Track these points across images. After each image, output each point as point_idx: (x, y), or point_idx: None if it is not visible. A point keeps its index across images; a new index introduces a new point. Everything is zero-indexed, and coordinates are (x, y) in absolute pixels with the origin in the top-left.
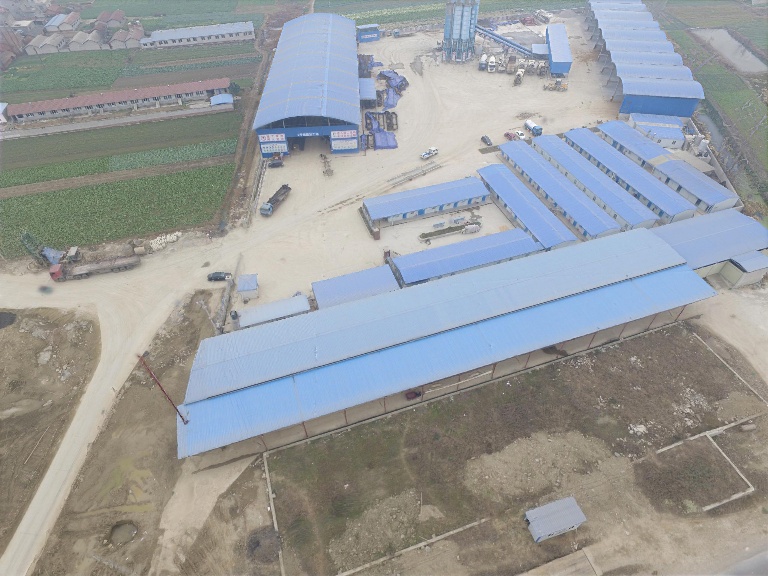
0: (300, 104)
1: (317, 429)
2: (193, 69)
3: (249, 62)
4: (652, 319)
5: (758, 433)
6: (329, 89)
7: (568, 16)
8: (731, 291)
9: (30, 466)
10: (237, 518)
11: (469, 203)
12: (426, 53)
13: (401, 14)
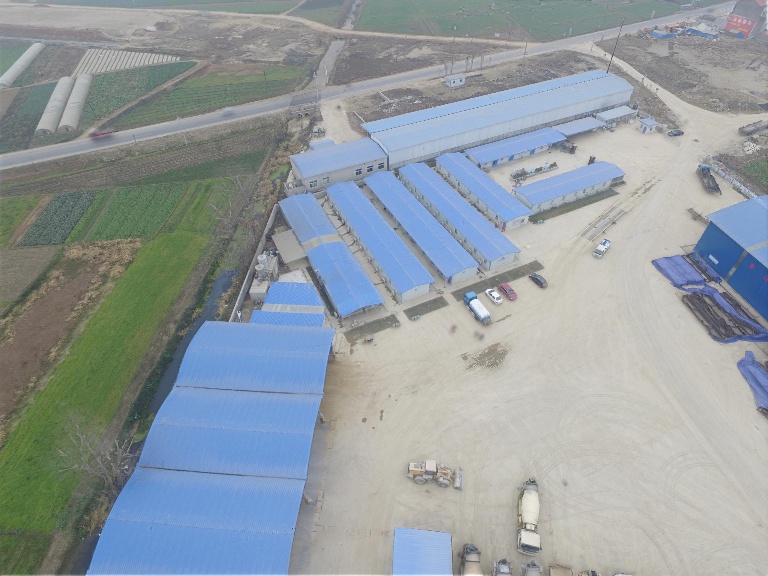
0: None
1: None
2: None
3: None
4: None
5: None
6: None
7: None
8: None
9: (659, 80)
10: None
11: None
12: None
13: None
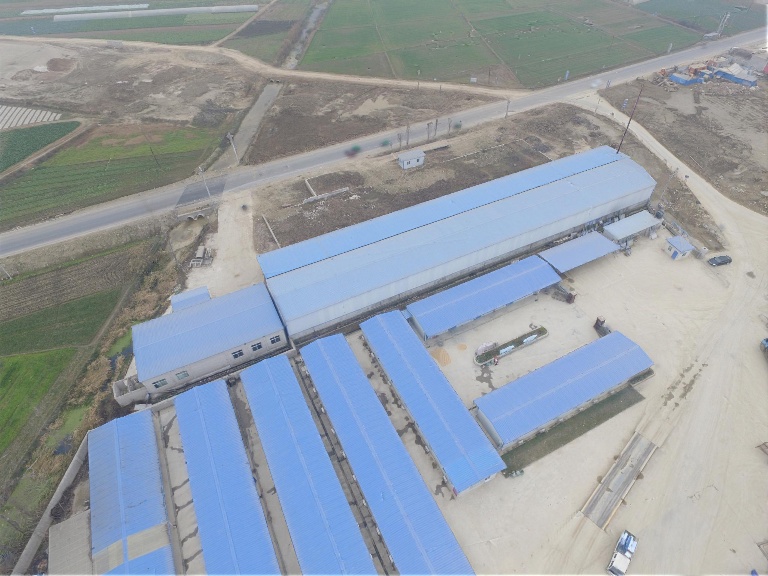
0: None
1: None
2: None
3: None
4: None
5: None
6: None
7: None
8: None
9: (686, 156)
10: (561, 153)
11: None
12: None
13: None
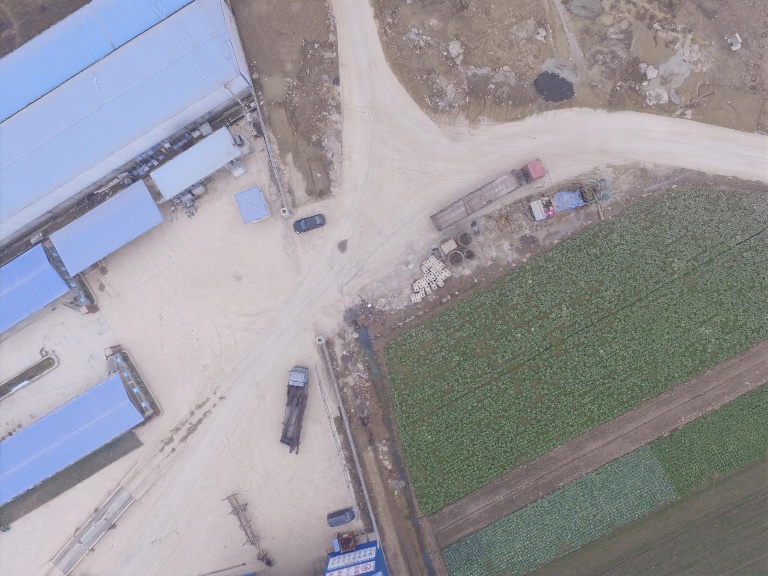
0: None
1: None
2: None
3: None
4: None
5: None
6: None
7: None
8: None
9: None
10: None
11: None
12: None
13: None
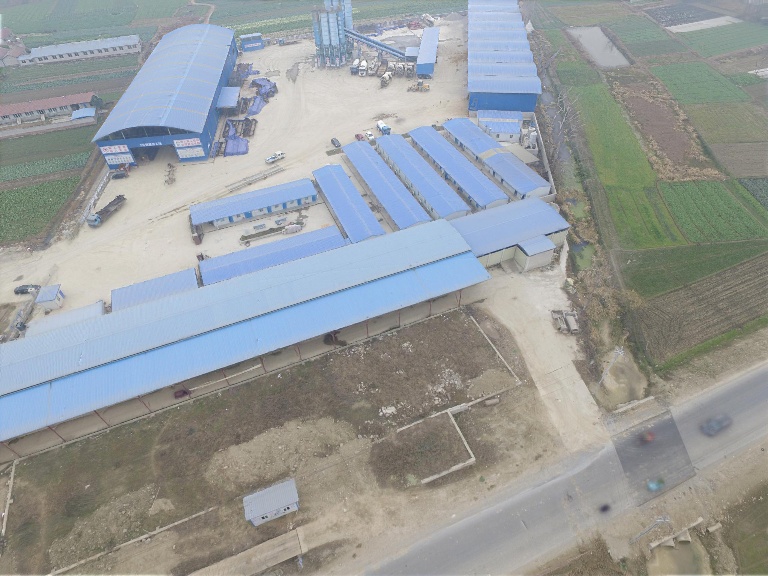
0: (141, 115)
1: (77, 433)
2: (68, 84)
3: (127, 75)
4: (429, 305)
5: (501, 407)
6: (177, 99)
7: (454, 19)
8: (520, 275)
9: None
10: None
11: (299, 204)
12: (305, 60)
13: (293, 22)
